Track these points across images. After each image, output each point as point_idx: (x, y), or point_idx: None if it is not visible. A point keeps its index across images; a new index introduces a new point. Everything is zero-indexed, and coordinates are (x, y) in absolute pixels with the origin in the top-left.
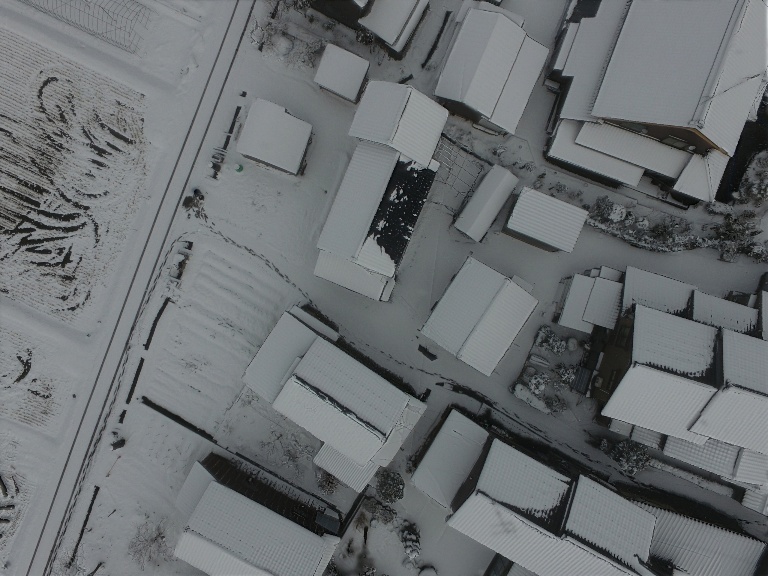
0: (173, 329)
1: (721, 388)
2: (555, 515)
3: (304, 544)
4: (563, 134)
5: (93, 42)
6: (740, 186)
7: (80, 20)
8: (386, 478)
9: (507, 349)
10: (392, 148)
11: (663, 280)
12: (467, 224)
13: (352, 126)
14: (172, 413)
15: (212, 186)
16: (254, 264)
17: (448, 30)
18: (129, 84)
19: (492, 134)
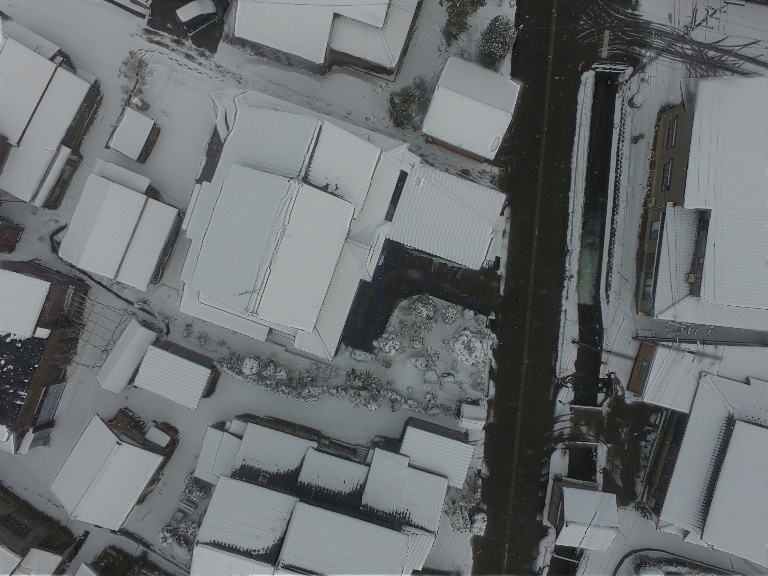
0: None
1: (275, 568)
2: None
3: None
4: (188, 293)
5: None
6: None
7: None
8: None
9: (134, 504)
10: None
11: (282, 437)
12: (103, 378)
13: None
14: None
15: None
16: None
17: None
18: None
19: None
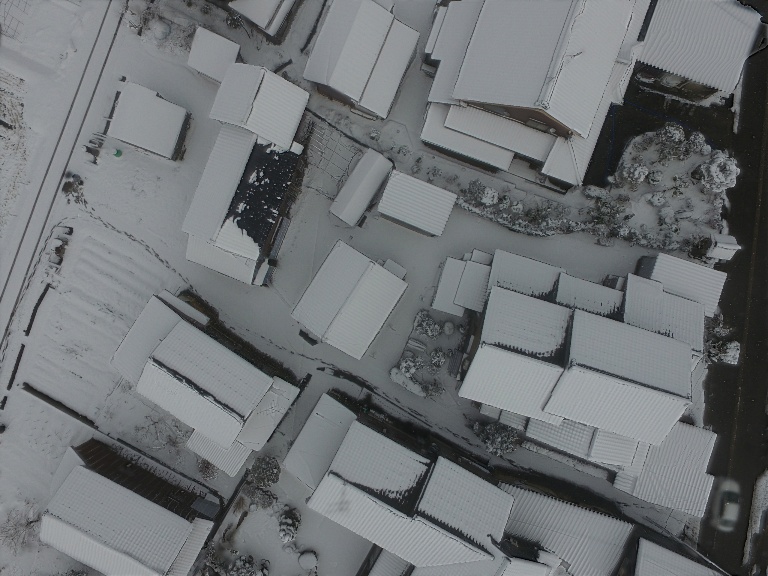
0: (53, 315)
1: (566, 368)
2: (410, 496)
3: (168, 527)
4: (433, 118)
5: None
6: (617, 170)
7: None
8: (261, 462)
9: (377, 332)
10: (247, 130)
11: (531, 263)
12: (340, 208)
13: (212, 109)
14: (54, 399)
15: (91, 171)
16: (134, 249)
17: None
18: (8, 69)
19: (370, 119)
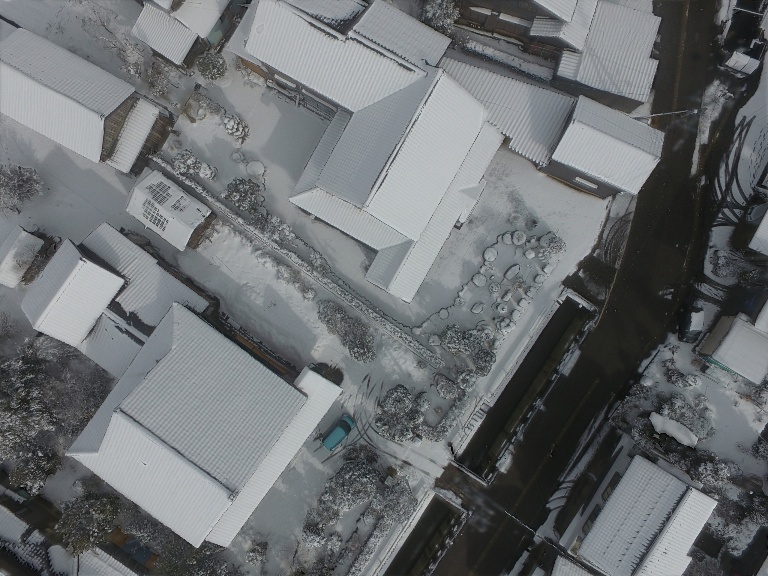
0: None
1: None
2: (345, 24)
3: (110, 85)
4: None
5: None
6: None
7: None
8: None
9: None
10: None
11: None
12: None
13: None
14: (6, 18)
15: None
16: None
17: None
18: None
19: None
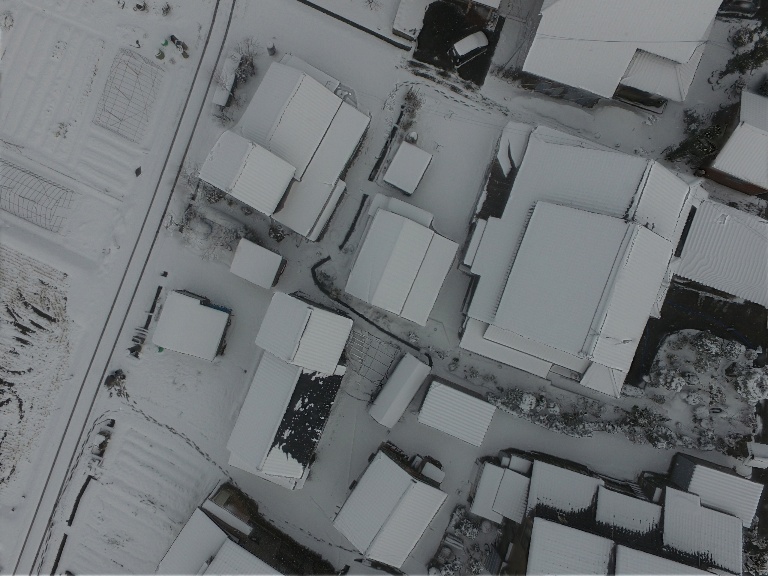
0: (96, 505)
1: None
2: None
3: None
4: (472, 329)
5: (17, 221)
6: (652, 368)
7: (2, 205)
8: None
9: (417, 541)
10: None
11: (569, 475)
12: (380, 414)
13: (258, 335)
14: None
15: (133, 365)
16: (175, 442)
17: (364, 215)
18: (52, 264)
19: None
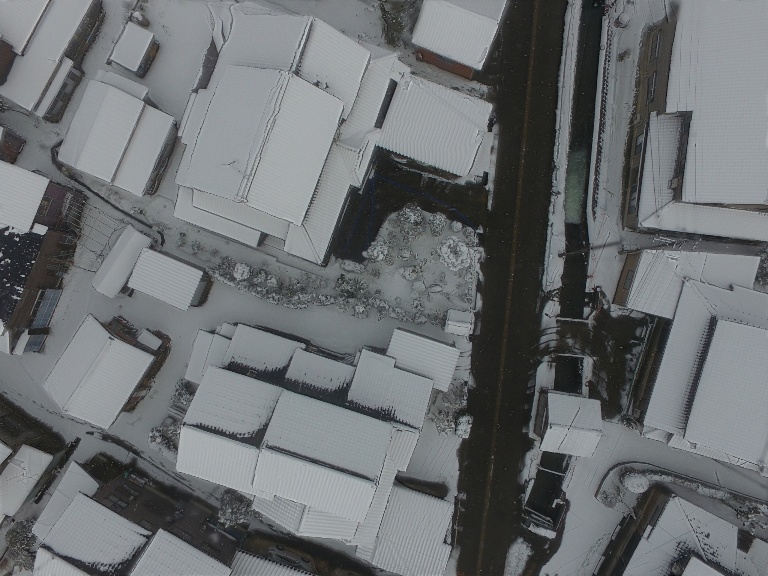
0: None
1: (260, 449)
2: (122, 569)
3: None
4: (182, 198)
5: None
6: None
7: None
8: (17, 526)
9: (125, 403)
10: None
11: (271, 338)
12: (98, 282)
13: None
14: None
15: None
16: None
17: None
18: None
19: None
